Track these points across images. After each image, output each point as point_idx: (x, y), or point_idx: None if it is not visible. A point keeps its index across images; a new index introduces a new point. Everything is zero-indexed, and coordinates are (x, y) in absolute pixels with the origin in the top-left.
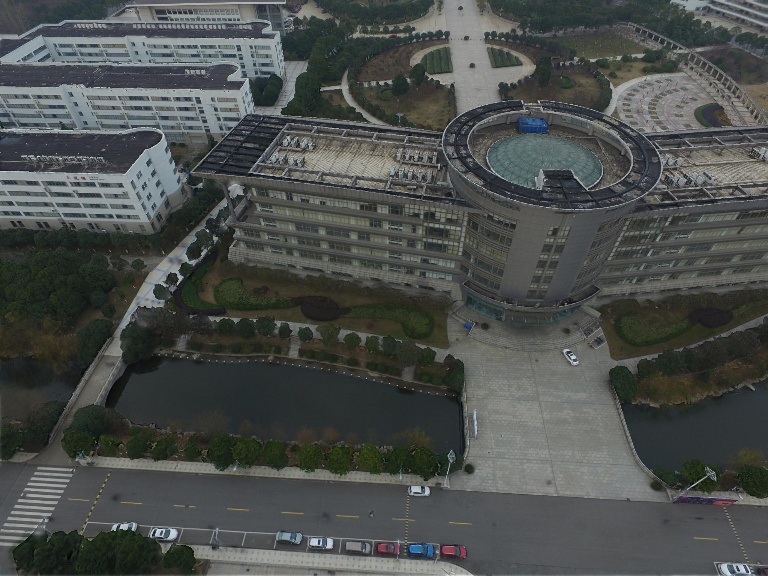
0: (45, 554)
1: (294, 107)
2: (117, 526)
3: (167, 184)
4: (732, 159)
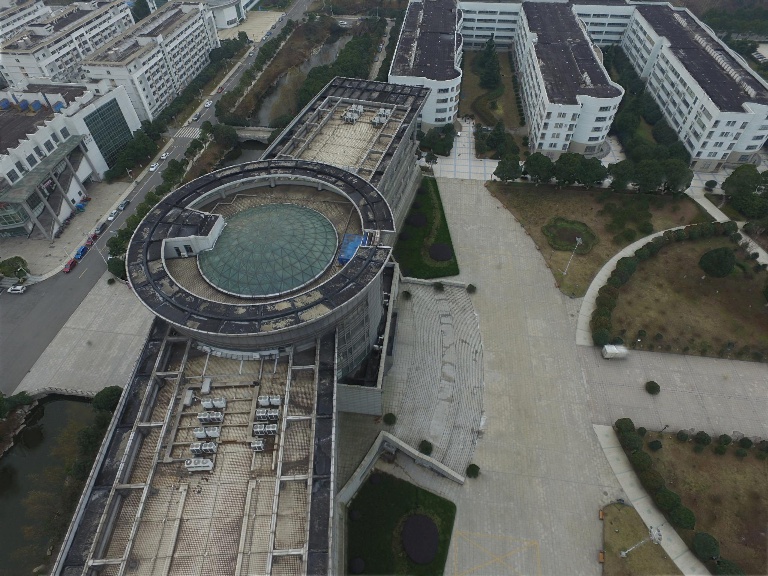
0: (144, 123)
1: (571, 157)
2: (166, 153)
3: (425, 113)
4: (251, 574)
